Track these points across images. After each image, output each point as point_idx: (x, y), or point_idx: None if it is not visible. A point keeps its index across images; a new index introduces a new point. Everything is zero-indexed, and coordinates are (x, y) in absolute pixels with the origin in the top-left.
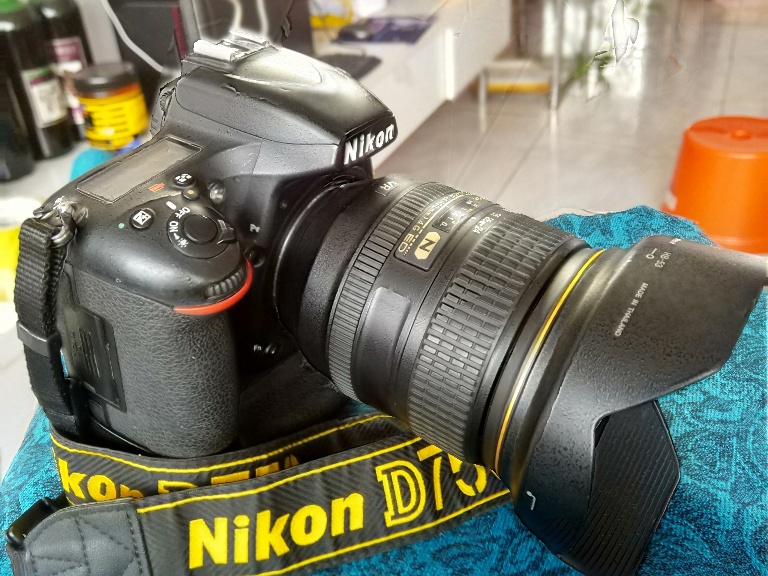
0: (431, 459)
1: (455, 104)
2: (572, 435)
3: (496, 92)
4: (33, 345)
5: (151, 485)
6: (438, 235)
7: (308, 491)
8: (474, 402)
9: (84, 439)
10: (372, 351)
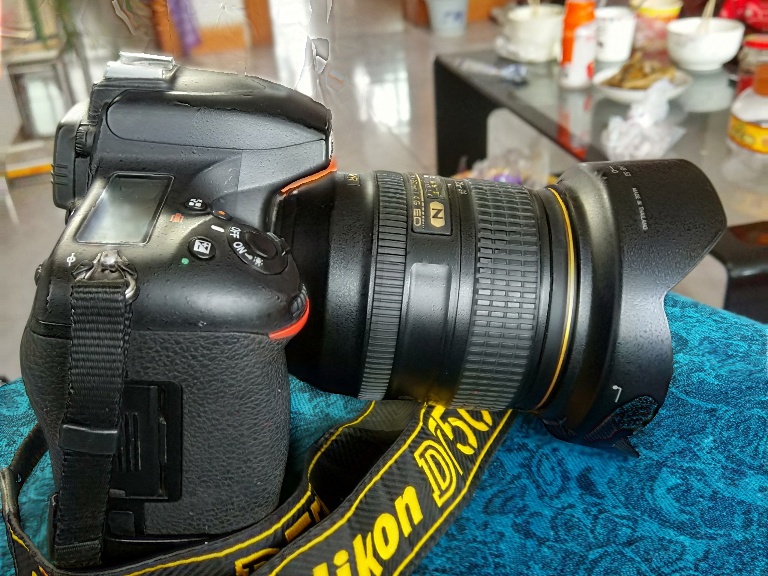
0: (436, 433)
1: None
2: (648, 318)
3: None
4: (94, 446)
5: (226, 572)
6: (439, 203)
7: (375, 502)
8: (535, 334)
9: (118, 562)
10: (421, 328)
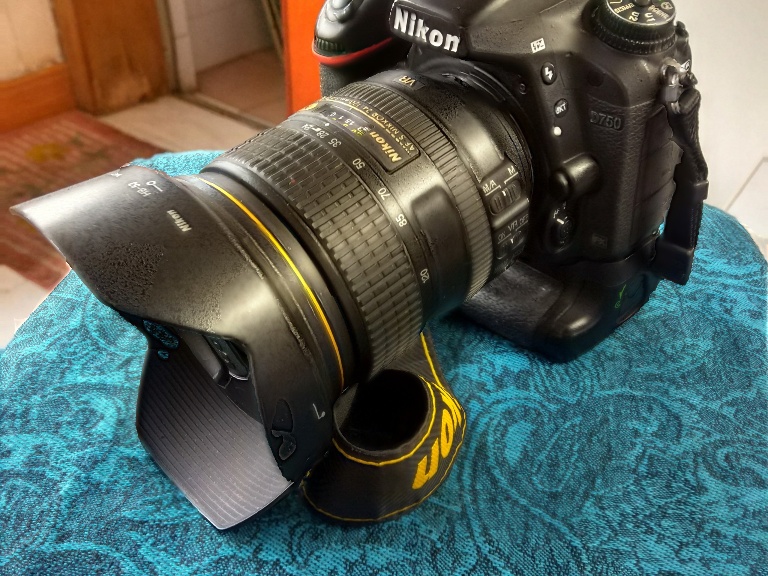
0: None
1: None
2: None
3: None
4: None
5: None
6: (312, 108)
7: None
8: None
9: None
10: None
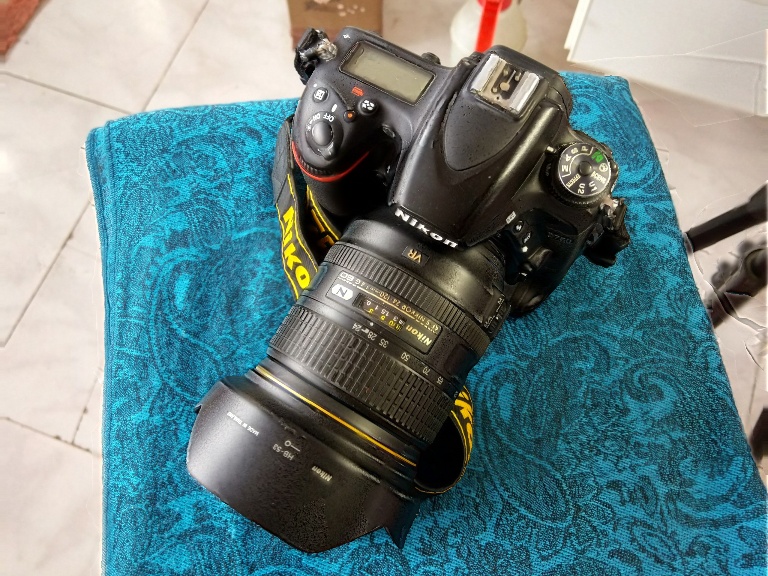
0: None
1: None
2: None
3: None
4: None
5: None
6: (350, 298)
7: None
8: None
9: None
10: None
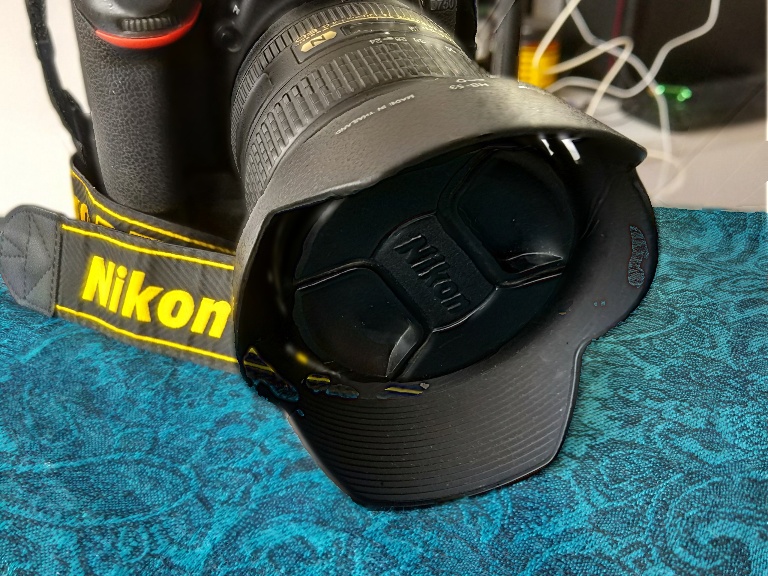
0: None
1: (715, 63)
2: None
3: (767, 58)
4: None
5: (93, 218)
6: (335, 35)
7: (188, 277)
8: None
9: None
10: (242, 139)
